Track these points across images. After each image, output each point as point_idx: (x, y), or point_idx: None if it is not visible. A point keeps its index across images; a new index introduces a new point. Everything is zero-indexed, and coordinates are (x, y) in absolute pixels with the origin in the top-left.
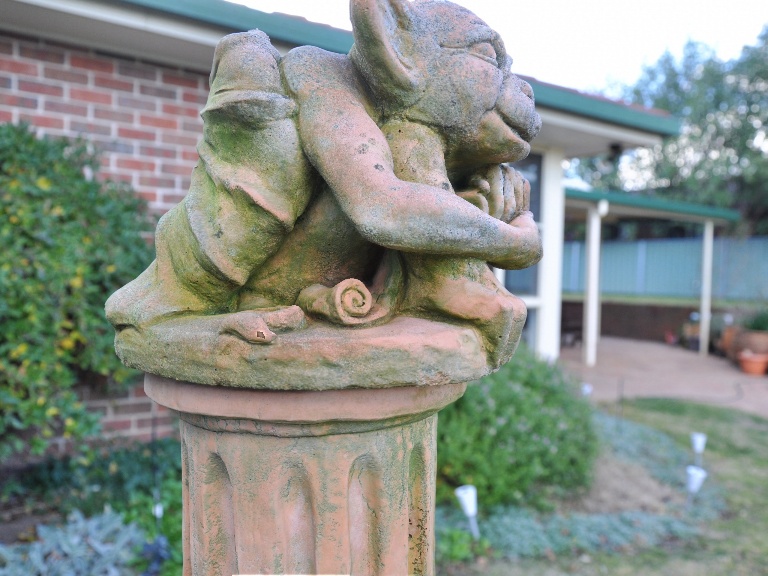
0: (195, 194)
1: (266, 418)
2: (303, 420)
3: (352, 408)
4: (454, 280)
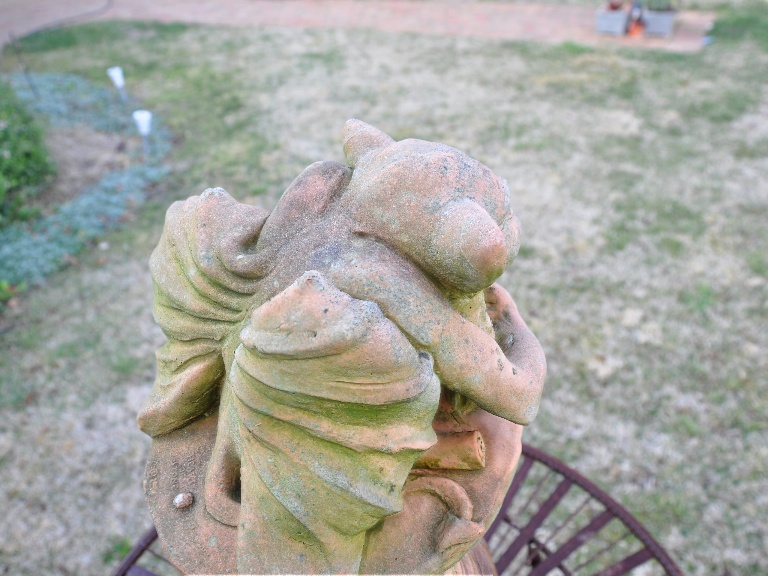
0: (324, 465)
1: None
2: None
3: None
4: None
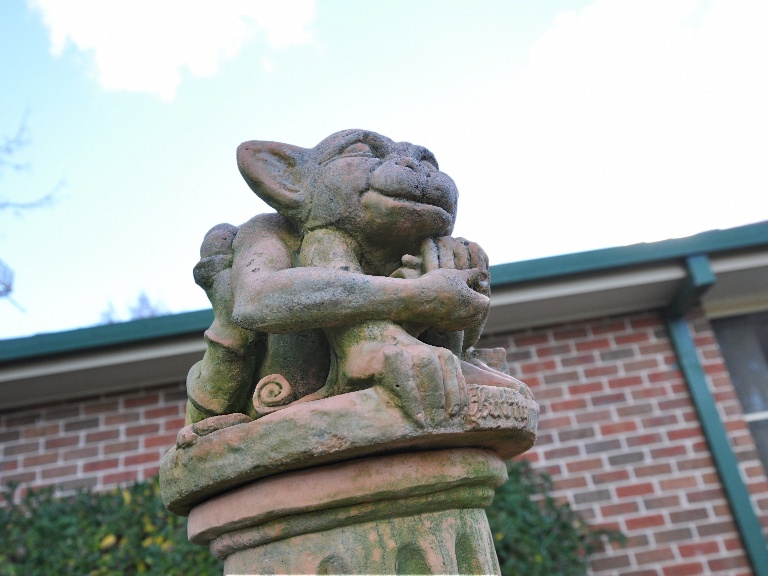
0: None
1: (222, 523)
2: (245, 518)
3: (283, 497)
4: (356, 347)
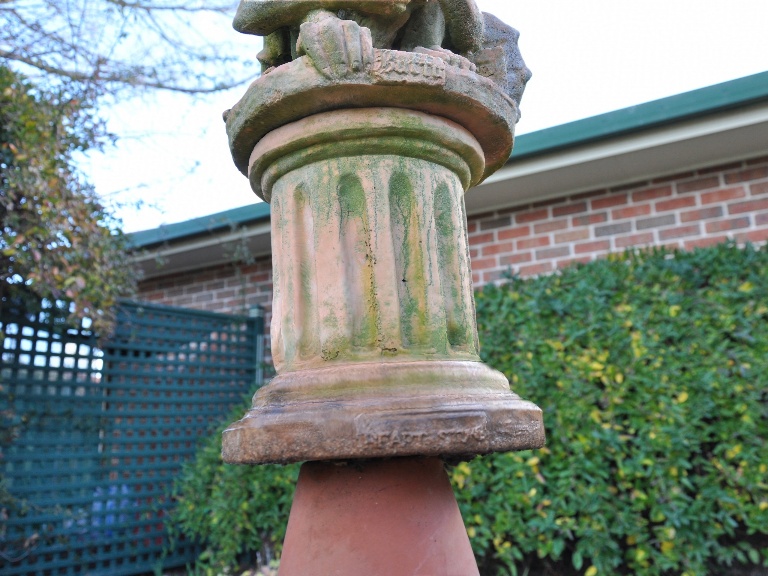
0: None
1: None
2: (255, 162)
3: None
4: None
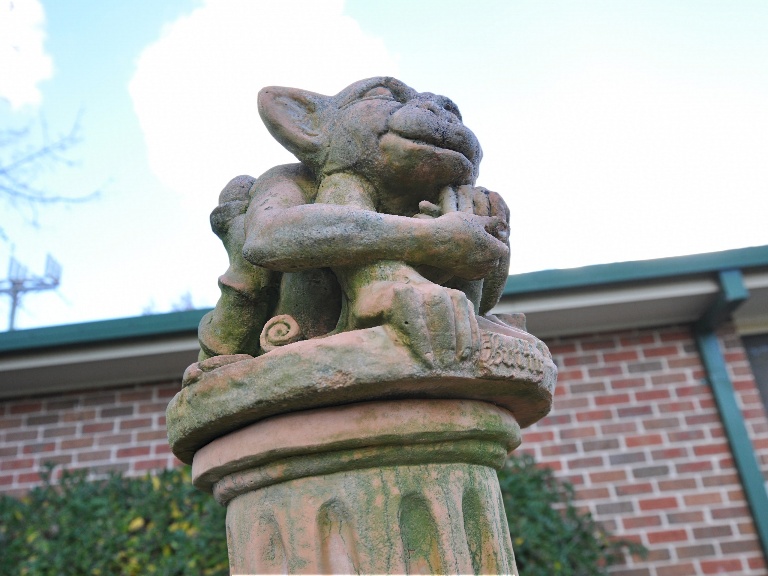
0: None
1: (223, 463)
2: (246, 456)
3: (286, 436)
4: (366, 286)
